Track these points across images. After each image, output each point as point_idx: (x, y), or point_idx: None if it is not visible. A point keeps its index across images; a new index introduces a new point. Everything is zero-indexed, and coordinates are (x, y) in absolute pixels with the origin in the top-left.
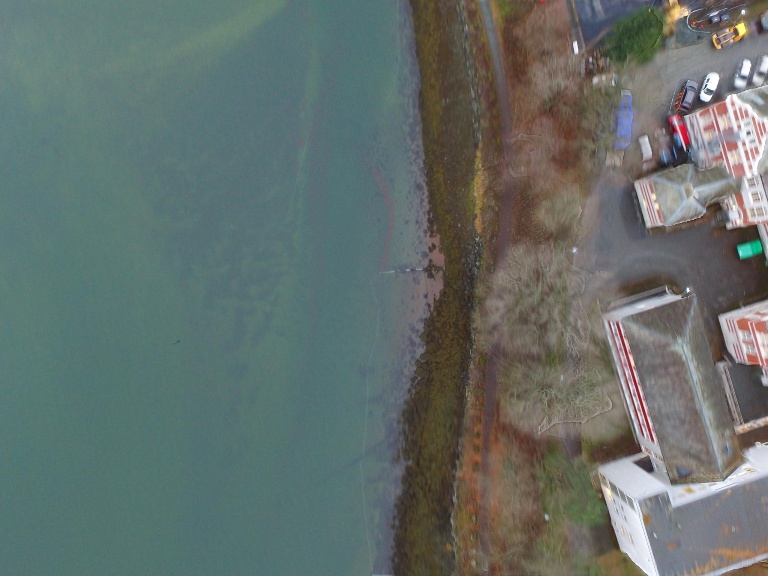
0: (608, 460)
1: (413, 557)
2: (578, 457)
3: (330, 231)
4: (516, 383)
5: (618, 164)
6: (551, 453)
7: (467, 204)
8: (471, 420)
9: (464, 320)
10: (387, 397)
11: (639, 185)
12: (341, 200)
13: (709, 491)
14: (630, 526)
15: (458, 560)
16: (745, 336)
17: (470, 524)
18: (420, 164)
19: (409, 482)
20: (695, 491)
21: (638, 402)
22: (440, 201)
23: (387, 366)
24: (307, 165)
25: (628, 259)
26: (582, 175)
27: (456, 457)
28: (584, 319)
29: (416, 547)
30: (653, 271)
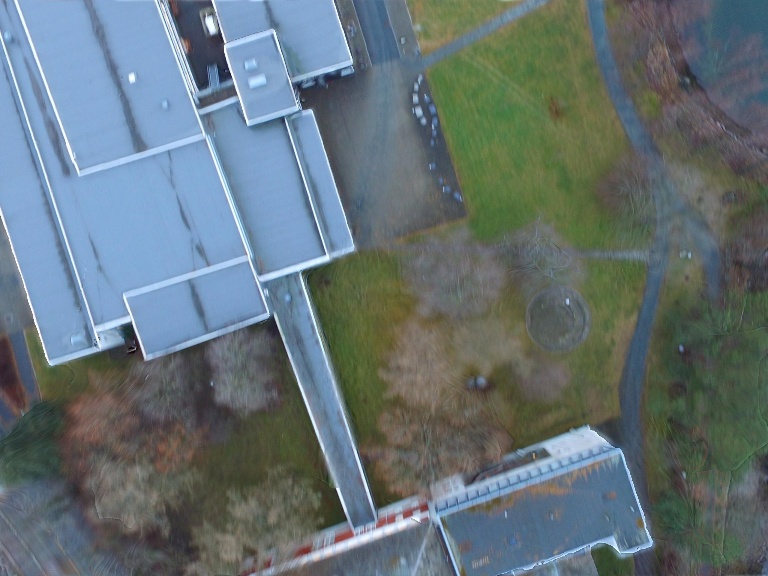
0: None
1: (764, 387)
2: None
3: None
4: None
5: None
6: (673, 530)
7: None
8: None
9: None
10: None
11: None
12: None
13: (575, 551)
14: None
15: None
16: None
17: None
18: None
19: None
20: None
21: None
22: None
23: None
24: None
25: None
26: None
27: None
28: None
29: (762, 397)
30: None
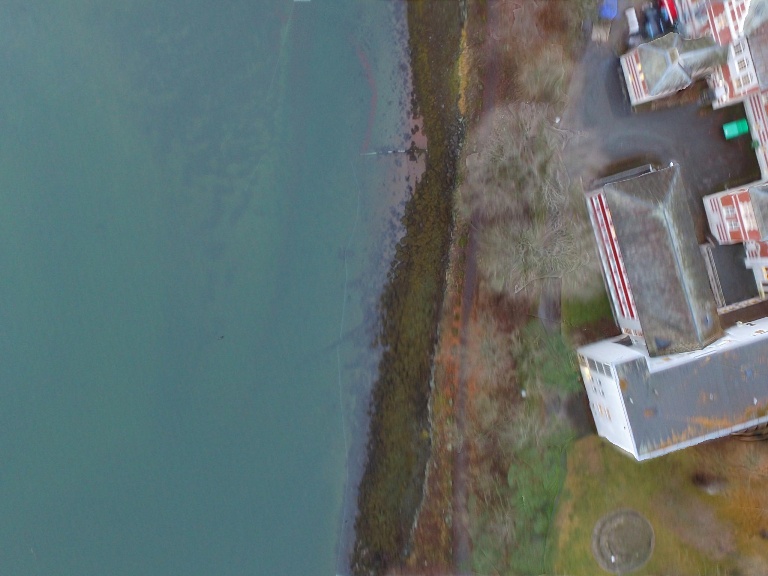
0: (588, 342)
1: (389, 444)
2: (557, 337)
3: (312, 110)
4: (496, 259)
5: (604, 39)
6: (530, 331)
7: (451, 84)
8: (450, 303)
9: (446, 203)
10: (366, 281)
11: (625, 59)
12: (324, 79)
13: (687, 358)
14: (607, 399)
15: (434, 445)
16: (728, 212)
17: (447, 408)
18: (405, 44)
19: (386, 368)
20: (673, 359)
21: (619, 278)
22: (424, 81)
23: (367, 249)
24: (290, 42)
25: (612, 137)
26: (567, 49)
27: (434, 342)
28: (563, 171)
29: (392, 434)
30: (637, 150)
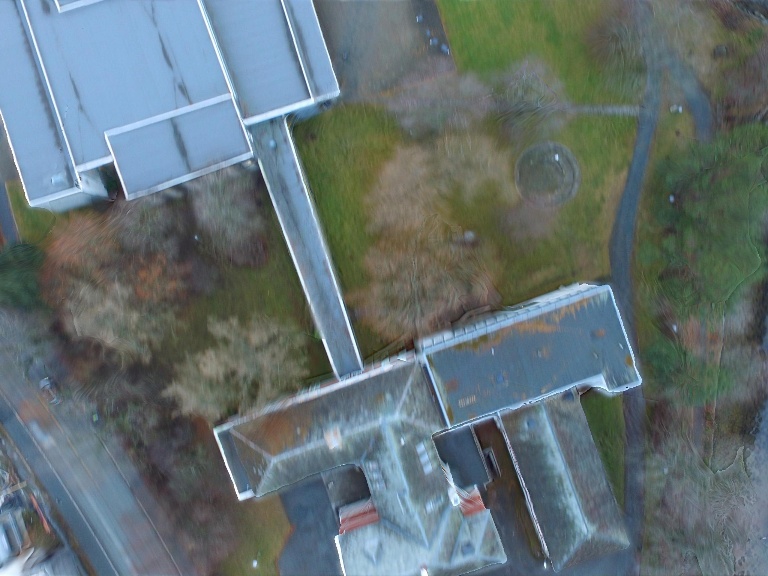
0: None
1: None
2: None
3: None
4: None
5: None
6: (663, 388)
7: None
8: None
9: None
10: None
11: None
12: None
13: (563, 390)
14: None
15: None
16: None
17: None
18: None
19: (761, 330)
20: None
21: None
22: None
23: None
24: None
25: None
26: None
27: None
28: (721, 574)
29: None
30: None
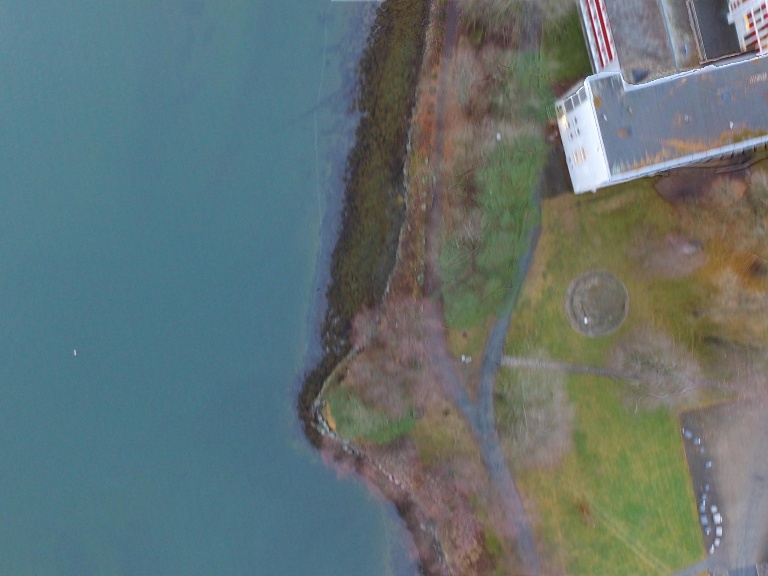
0: (566, 97)
1: (363, 210)
2: (535, 88)
3: None
4: (475, 4)
5: None
6: None
7: None
8: (429, 62)
9: None
10: (345, 46)
11: None
12: None
13: (663, 79)
14: (582, 134)
15: (409, 208)
16: None
17: (422, 167)
18: None
19: (363, 133)
20: (649, 82)
21: (598, 22)
22: None
23: (347, 14)
24: None
25: None
26: None
27: (412, 105)
28: None
29: (367, 200)
30: None
